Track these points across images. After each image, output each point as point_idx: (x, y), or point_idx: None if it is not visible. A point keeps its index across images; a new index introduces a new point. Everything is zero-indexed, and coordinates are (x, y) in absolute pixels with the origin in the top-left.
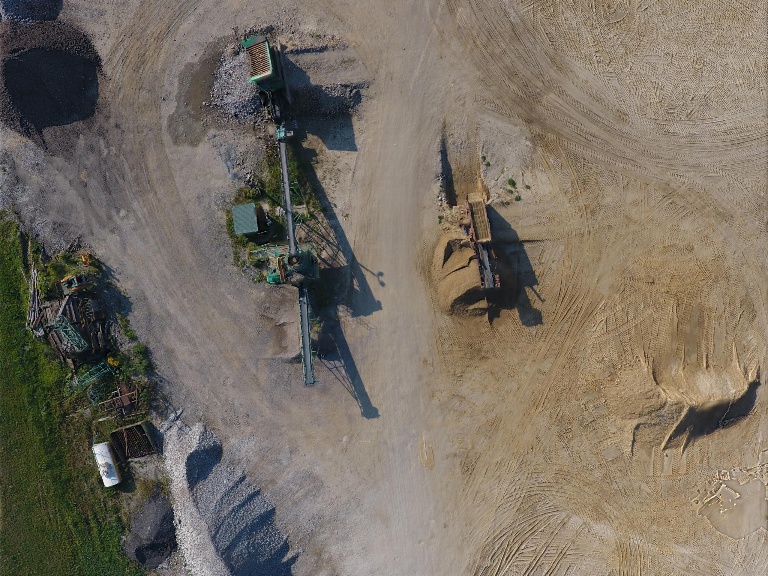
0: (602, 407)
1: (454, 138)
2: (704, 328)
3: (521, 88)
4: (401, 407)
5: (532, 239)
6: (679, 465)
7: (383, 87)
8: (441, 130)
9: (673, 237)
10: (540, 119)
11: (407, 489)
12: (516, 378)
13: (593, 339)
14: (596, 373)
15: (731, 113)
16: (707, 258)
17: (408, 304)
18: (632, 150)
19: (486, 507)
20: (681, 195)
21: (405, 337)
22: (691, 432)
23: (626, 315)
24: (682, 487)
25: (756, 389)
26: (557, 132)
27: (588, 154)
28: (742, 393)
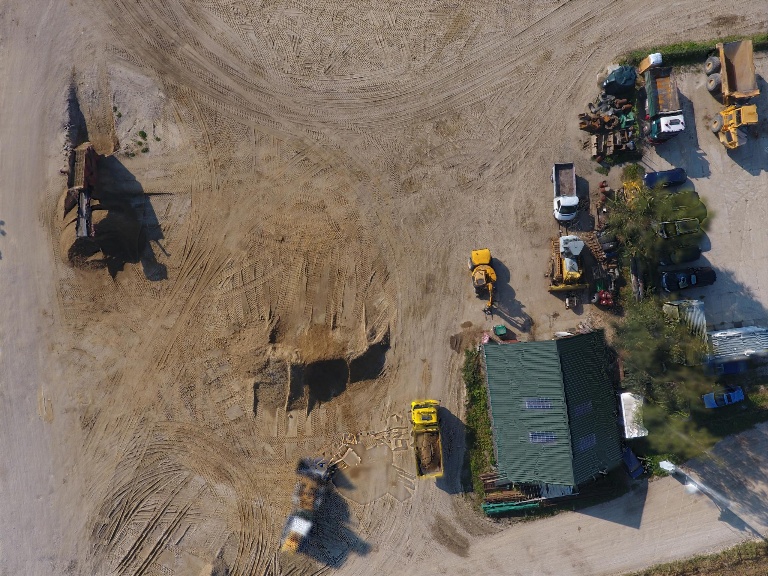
0: (226, 365)
1: (85, 87)
2: (334, 288)
3: (154, 38)
4: (18, 359)
5: (157, 192)
6: (304, 427)
7: (9, 33)
8: (70, 78)
9: (305, 194)
10: (174, 70)
11: (25, 443)
12: (138, 333)
13: (219, 296)
14: (221, 331)
15: (370, 70)
16: (340, 217)
17: (29, 254)
18: (267, 105)
19: (106, 463)
20: (315, 152)
21: (24, 288)
22: (311, 393)
23: (254, 272)
24: (307, 450)
25: (385, 352)
26: (190, 84)
27: (221, 107)
28: (359, 354)
